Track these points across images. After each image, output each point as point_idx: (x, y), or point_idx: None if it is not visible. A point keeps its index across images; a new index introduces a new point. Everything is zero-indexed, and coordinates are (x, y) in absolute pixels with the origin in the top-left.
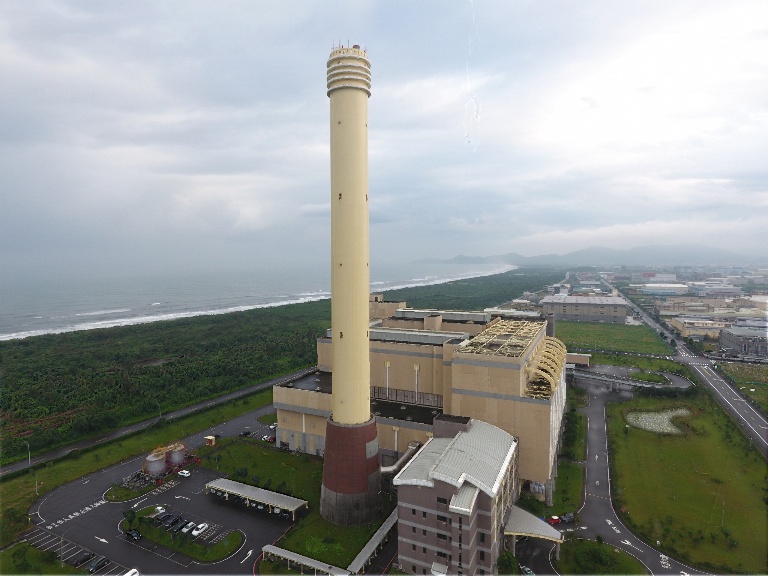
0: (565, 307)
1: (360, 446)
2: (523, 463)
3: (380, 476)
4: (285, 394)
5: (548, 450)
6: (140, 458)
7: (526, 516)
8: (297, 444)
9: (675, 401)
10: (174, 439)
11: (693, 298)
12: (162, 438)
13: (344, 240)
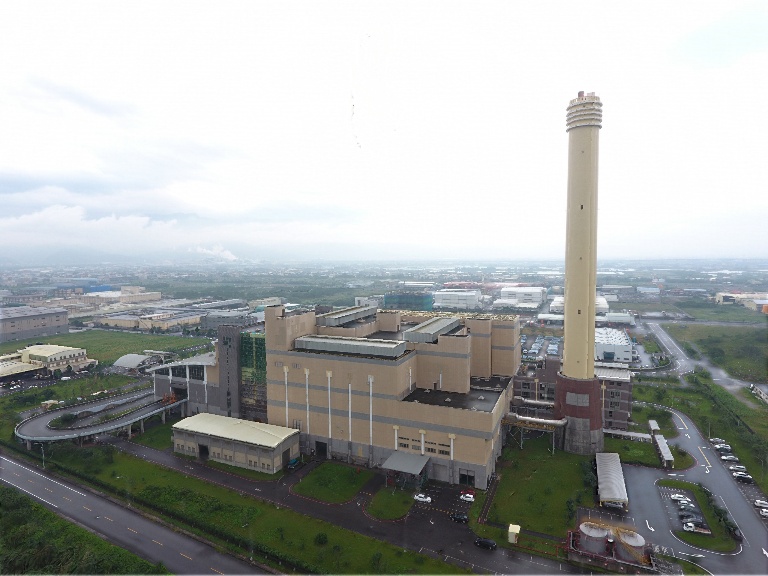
0: None
1: None
2: None
3: None
4: None
5: None
6: None
7: None
8: (491, 468)
9: None
10: None
11: (44, 301)
12: None
13: None
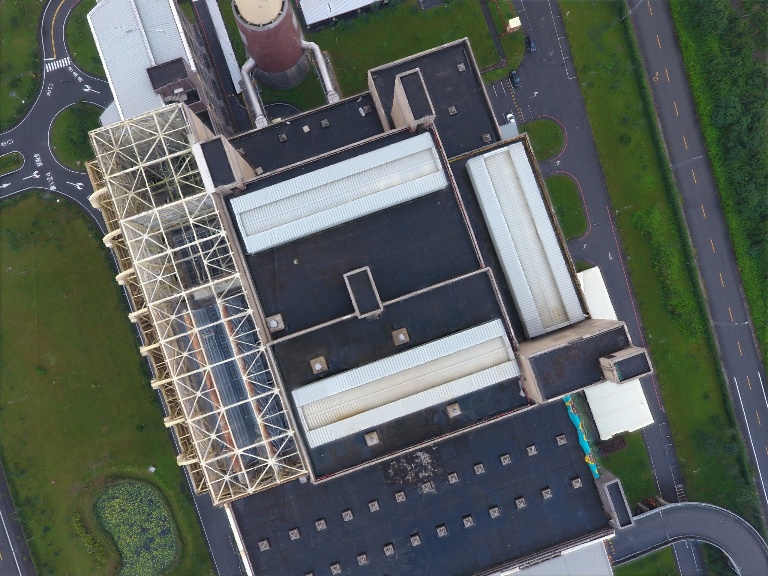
0: None
1: None
2: None
3: None
4: None
5: None
6: None
7: None
8: None
9: None
10: (562, 3)
11: None
12: None
13: None
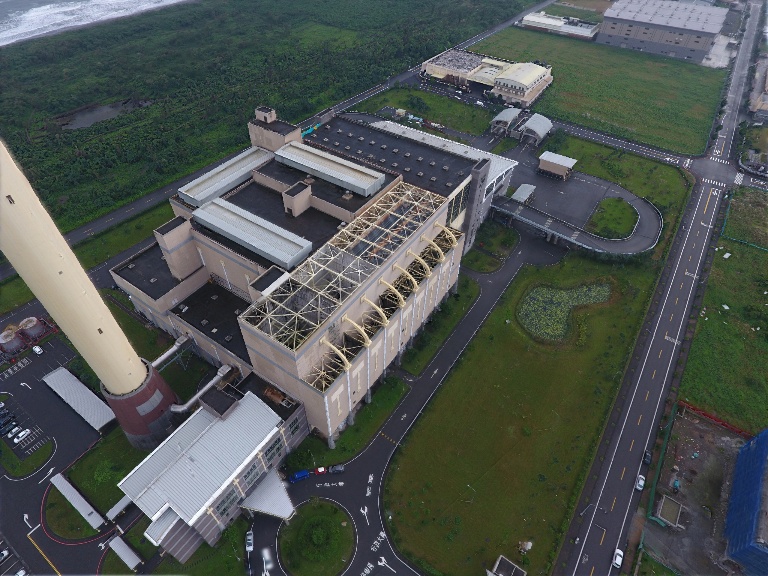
0: (631, 27)
1: (129, 410)
2: (309, 417)
3: (168, 416)
4: (121, 282)
5: (326, 421)
6: (11, 317)
7: (274, 486)
8: (150, 318)
9: (606, 273)
10: None
11: None
12: None
13: (6, 255)
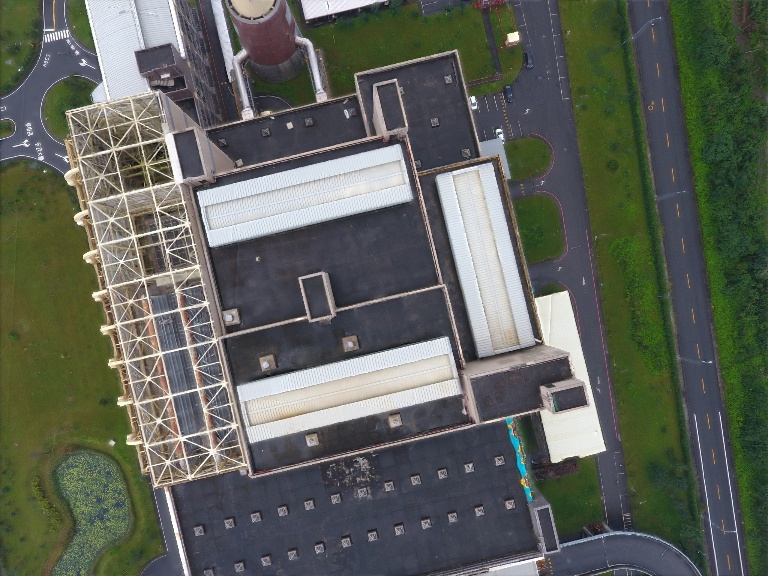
0: None
1: None
2: None
3: None
4: None
5: None
6: None
7: None
8: None
9: None
10: (564, 22)
11: None
12: (578, 12)
13: None
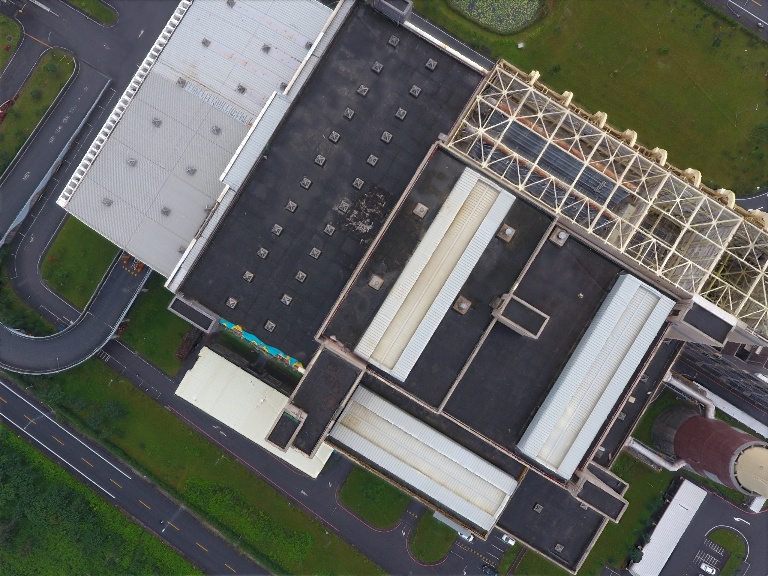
0: None
1: None
2: None
3: None
4: None
5: None
6: None
7: None
8: None
9: None
10: None
11: None
12: None
13: None
